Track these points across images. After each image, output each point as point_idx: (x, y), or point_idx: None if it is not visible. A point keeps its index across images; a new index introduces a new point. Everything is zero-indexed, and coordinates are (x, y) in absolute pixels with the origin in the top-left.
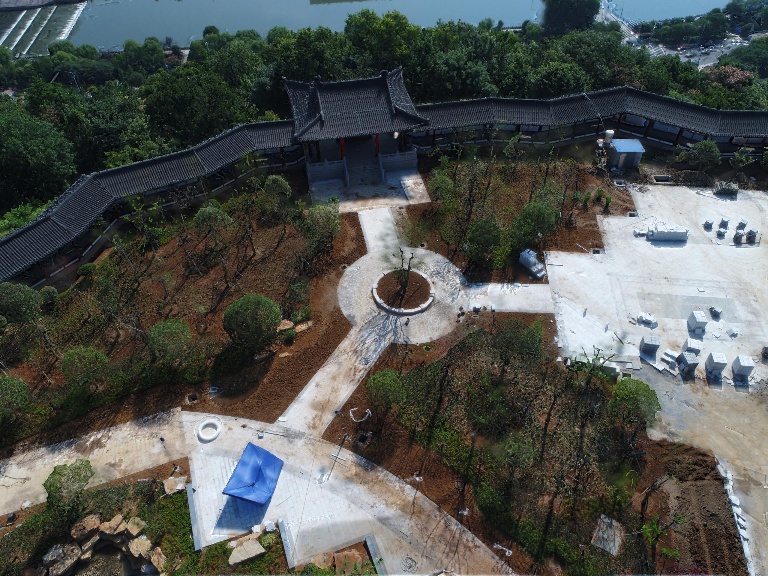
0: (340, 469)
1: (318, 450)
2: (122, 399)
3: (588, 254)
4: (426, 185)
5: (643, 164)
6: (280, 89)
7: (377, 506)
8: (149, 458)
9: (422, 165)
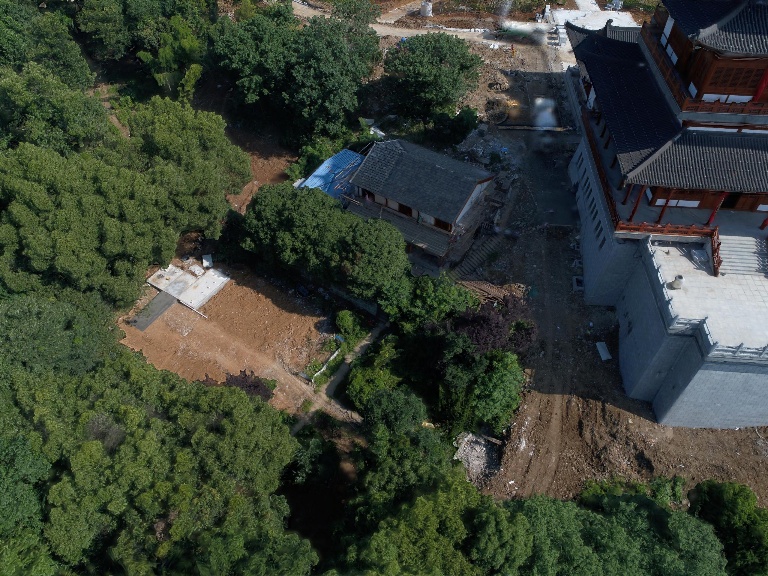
0: None
1: None
2: None
3: None
4: None
5: None
6: None
7: None
8: None
9: None
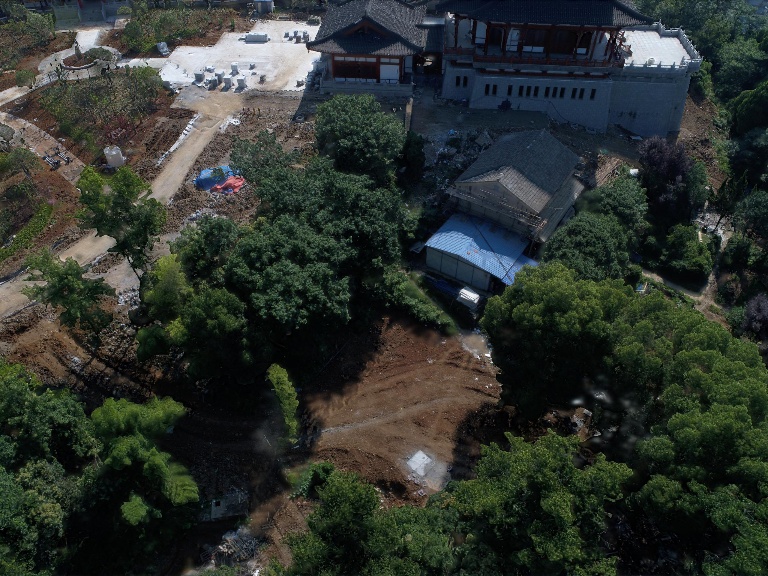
0: None
1: None
2: None
3: (203, 47)
4: (131, 21)
5: (278, 12)
6: None
7: None
8: None
9: (135, 13)
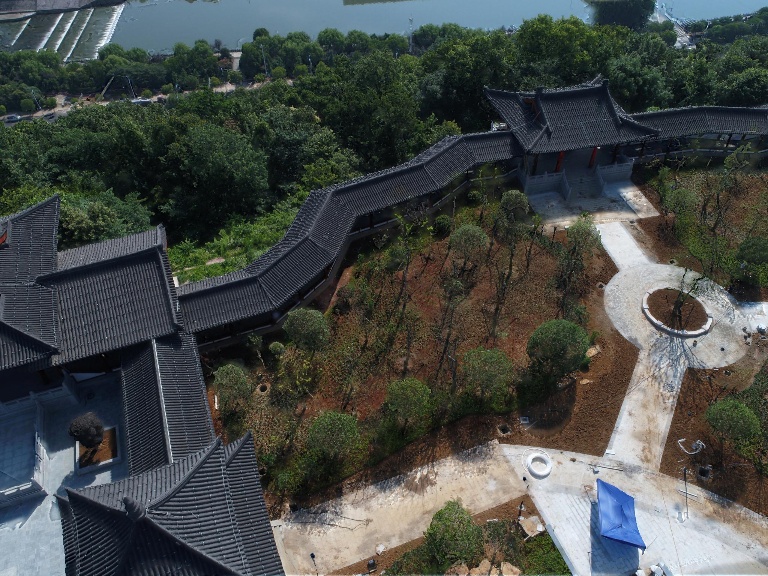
0: (696, 506)
1: (663, 485)
2: (434, 431)
3: None
4: (648, 197)
5: None
6: (450, 97)
7: (753, 547)
8: (488, 496)
9: (634, 176)
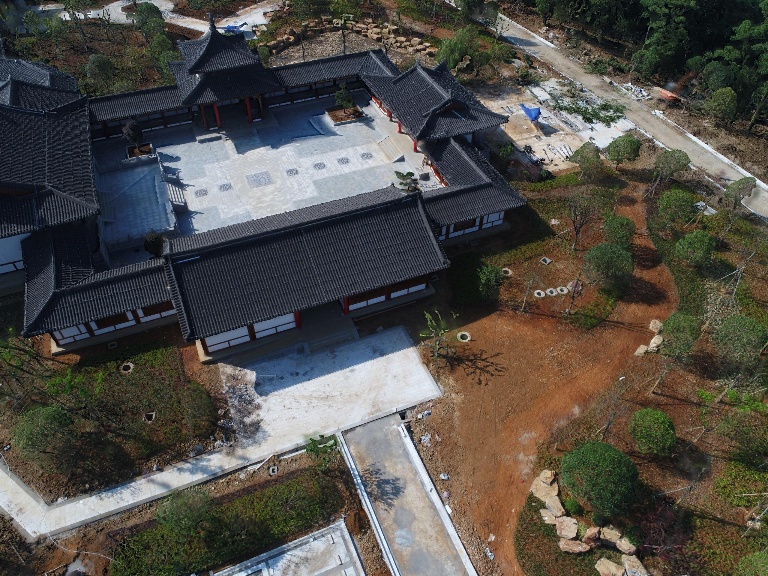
0: None
1: None
2: None
3: None
4: (48, 4)
5: None
6: None
7: None
8: None
9: None
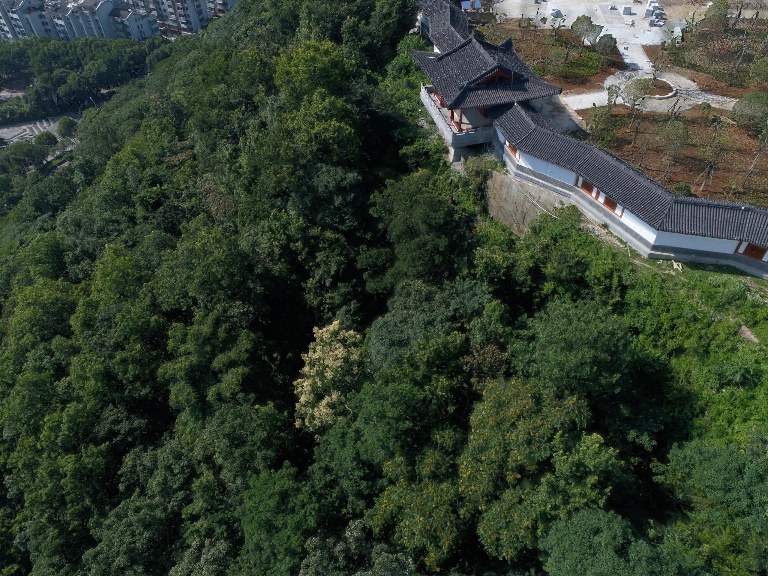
0: None
1: None
2: None
3: None
4: None
5: None
6: None
7: None
8: None
9: None
